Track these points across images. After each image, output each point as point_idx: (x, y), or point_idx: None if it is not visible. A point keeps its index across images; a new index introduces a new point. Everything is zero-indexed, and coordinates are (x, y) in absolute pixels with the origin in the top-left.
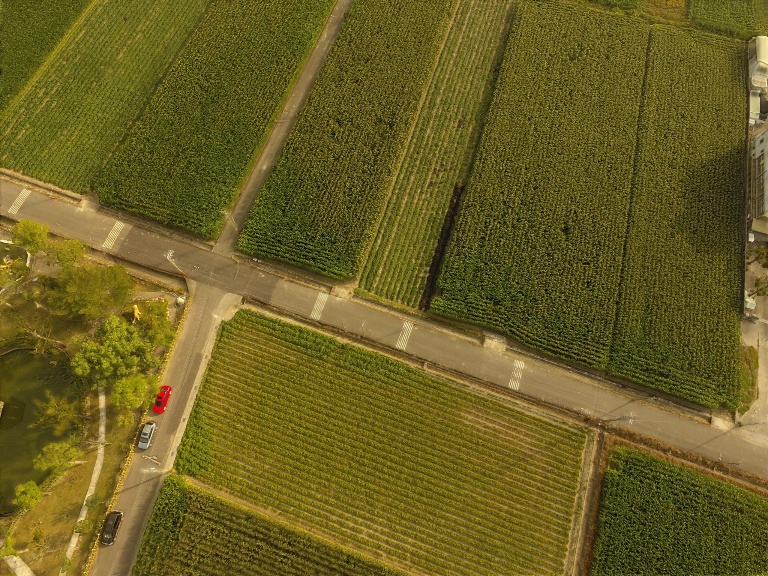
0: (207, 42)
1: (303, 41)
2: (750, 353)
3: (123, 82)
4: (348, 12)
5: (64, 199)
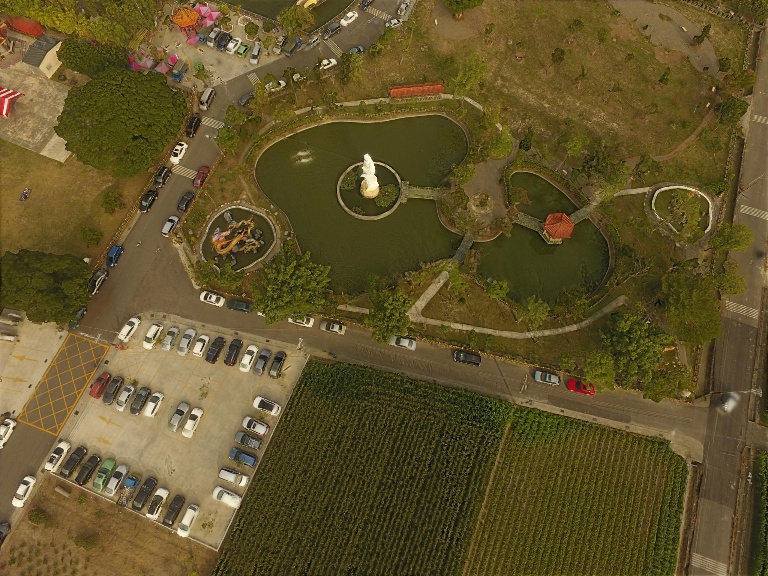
0: None
1: None
2: None
3: None
4: None
5: None
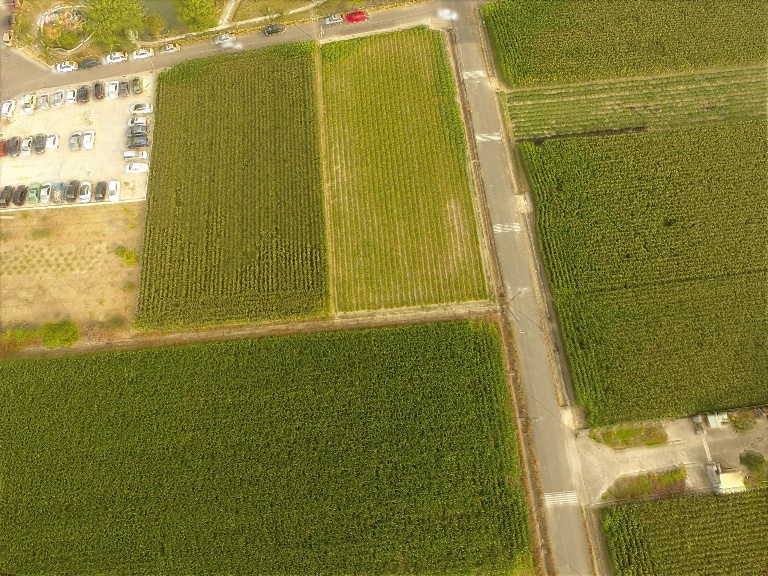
0: None
1: None
2: (659, 433)
3: None
4: None
5: None
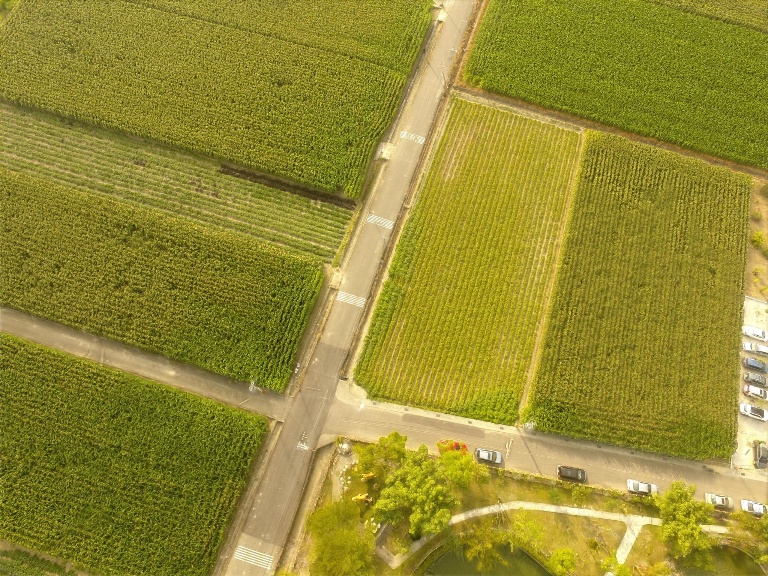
0: None
1: None
2: None
3: None
4: None
5: None
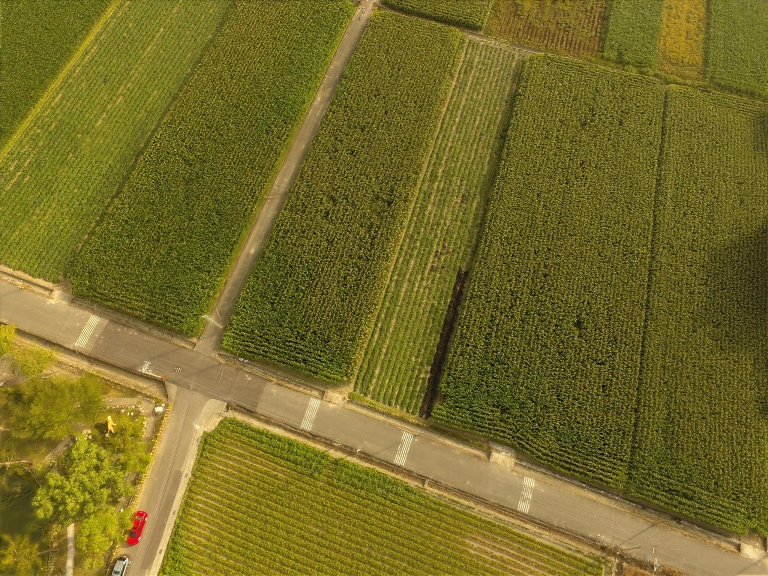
0: (192, 108)
1: (295, 107)
2: None
3: (101, 153)
4: (343, 74)
5: (34, 289)
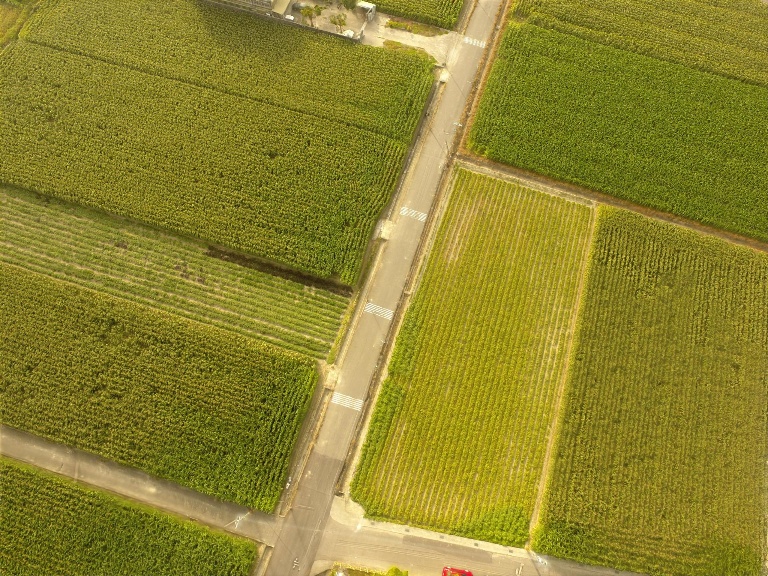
0: None
1: None
2: (389, 45)
3: None
4: None
5: None
